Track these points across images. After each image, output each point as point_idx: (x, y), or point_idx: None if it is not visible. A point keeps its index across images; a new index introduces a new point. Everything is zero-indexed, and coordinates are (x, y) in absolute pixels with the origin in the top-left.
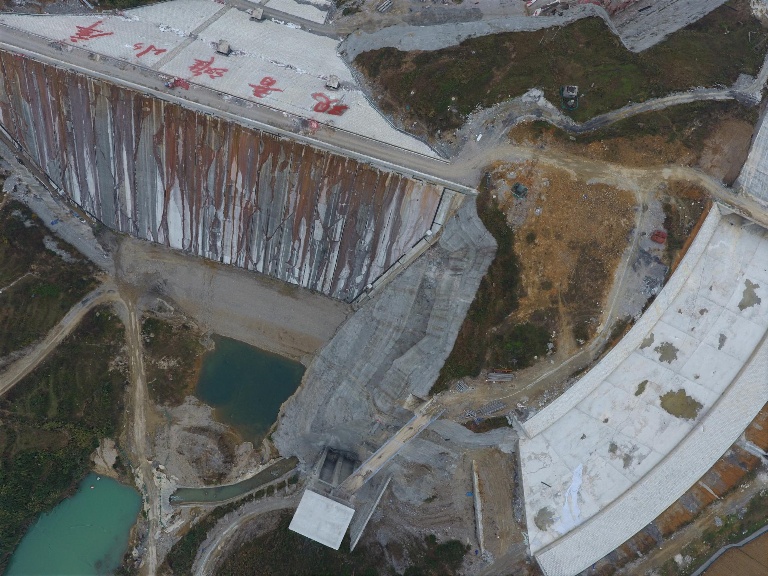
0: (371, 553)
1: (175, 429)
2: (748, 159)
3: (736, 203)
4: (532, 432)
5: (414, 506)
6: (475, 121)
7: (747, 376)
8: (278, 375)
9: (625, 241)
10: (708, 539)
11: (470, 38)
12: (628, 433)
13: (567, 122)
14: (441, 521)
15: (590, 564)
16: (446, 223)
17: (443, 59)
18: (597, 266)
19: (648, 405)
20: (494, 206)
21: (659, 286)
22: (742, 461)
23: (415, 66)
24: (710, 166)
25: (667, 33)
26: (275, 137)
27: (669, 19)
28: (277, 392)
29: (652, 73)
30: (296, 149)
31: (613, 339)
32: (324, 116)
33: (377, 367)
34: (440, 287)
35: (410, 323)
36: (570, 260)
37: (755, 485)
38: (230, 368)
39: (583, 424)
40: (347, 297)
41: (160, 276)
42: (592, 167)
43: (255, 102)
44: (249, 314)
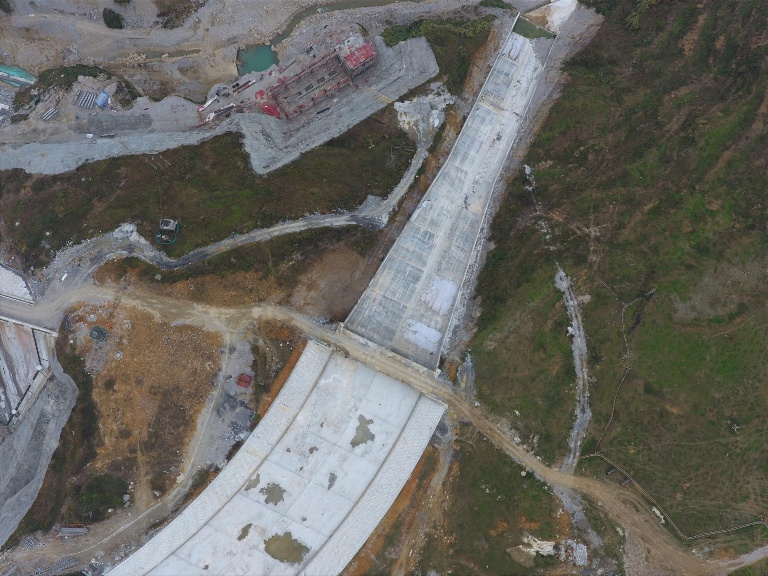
0: None
1: None
2: (376, 284)
3: (333, 341)
4: None
5: None
6: (61, 259)
7: (351, 519)
8: None
9: (210, 385)
10: None
11: (87, 163)
12: None
13: (161, 258)
14: None
15: None
16: None
17: (57, 186)
18: (179, 412)
19: (251, 550)
20: (71, 351)
21: (246, 431)
22: None
23: (32, 192)
24: (303, 304)
25: (309, 148)
26: None
27: (330, 127)
28: None
29: (266, 199)
30: None
31: (194, 489)
32: None
33: None
34: None
35: (25, 460)
36: (151, 406)
37: None
38: None
39: (182, 571)
40: (1, 419)
41: None
42: (178, 307)
43: None
44: None
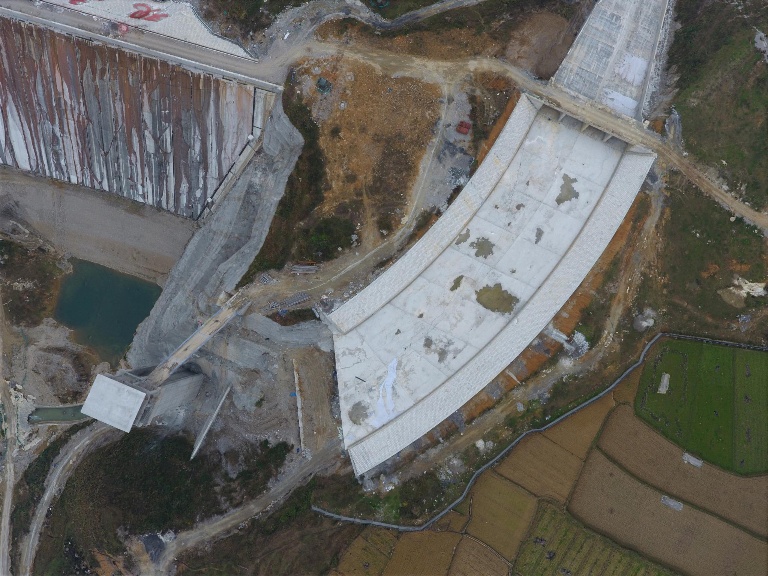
0: (210, 461)
1: (32, 349)
2: (571, 57)
3: (545, 94)
4: (343, 326)
5: (250, 413)
6: (283, 20)
7: (561, 268)
8: (137, 297)
9: (430, 133)
10: (510, 424)
11: None
12: (443, 328)
13: (376, 19)
14: (272, 425)
15: (395, 452)
16: (265, 126)
17: None
18: (402, 158)
19: (463, 300)
20: (298, 101)
21: (465, 177)
22: (547, 348)
23: None
24: (517, 57)
25: None
26: (88, 42)
27: None
28: (135, 314)
29: None
30: (110, 54)
31: (418, 230)
32: (138, 21)
33: (204, 272)
34: (263, 191)
35: (236, 228)
36: (375, 153)
37: (557, 370)
38: (89, 291)
39: (398, 319)
40: (192, 214)
41: (11, 198)
42: (397, 61)
43: (66, 7)
44: (101, 235)
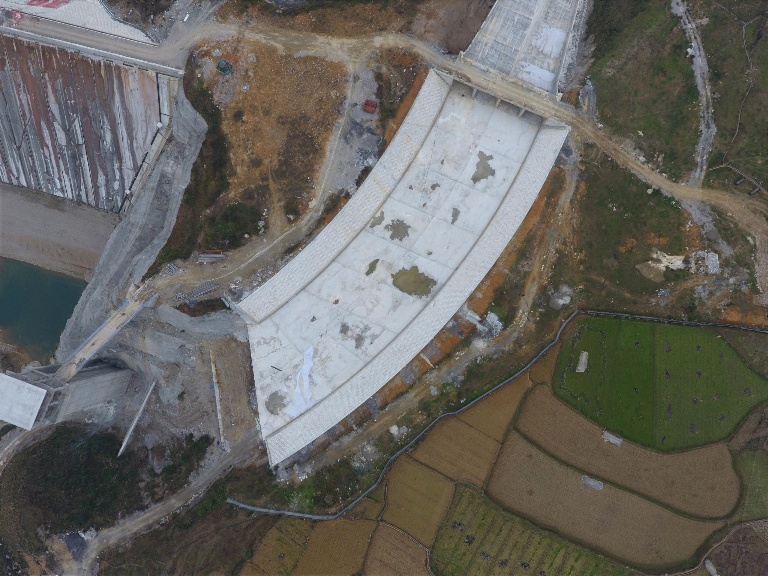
0: (137, 457)
1: None
2: (486, 30)
3: (454, 69)
4: (255, 315)
5: (176, 407)
6: (182, 1)
7: (478, 248)
8: (65, 294)
9: (336, 113)
10: (424, 409)
11: None
12: (359, 313)
13: None
14: (196, 418)
15: (309, 441)
16: (172, 113)
17: None
18: (308, 140)
19: (379, 284)
20: (199, 85)
21: (373, 157)
22: (461, 330)
23: None
24: (423, 31)
25: None
26: None
27: None
28: (65, 311)
29: None
30: (7, 43)
31: (326, 214)
32: (36, 9)
33: (118, 266)
34: None
35: (149, 219)
36: (279, 136)
37: (470, 352)
38: (17, 290)
39: (313, 306)
40: (113, 207)
41: None
42: (300, 40)
43: None
44: (23, 232)
